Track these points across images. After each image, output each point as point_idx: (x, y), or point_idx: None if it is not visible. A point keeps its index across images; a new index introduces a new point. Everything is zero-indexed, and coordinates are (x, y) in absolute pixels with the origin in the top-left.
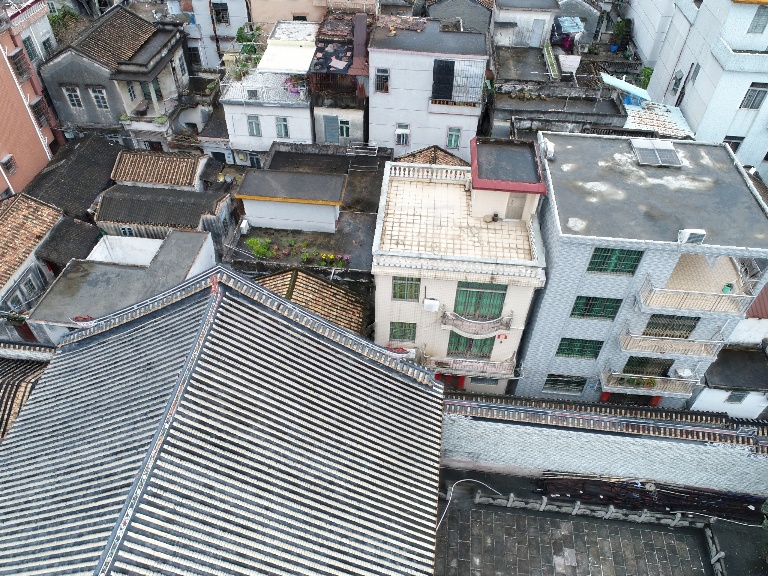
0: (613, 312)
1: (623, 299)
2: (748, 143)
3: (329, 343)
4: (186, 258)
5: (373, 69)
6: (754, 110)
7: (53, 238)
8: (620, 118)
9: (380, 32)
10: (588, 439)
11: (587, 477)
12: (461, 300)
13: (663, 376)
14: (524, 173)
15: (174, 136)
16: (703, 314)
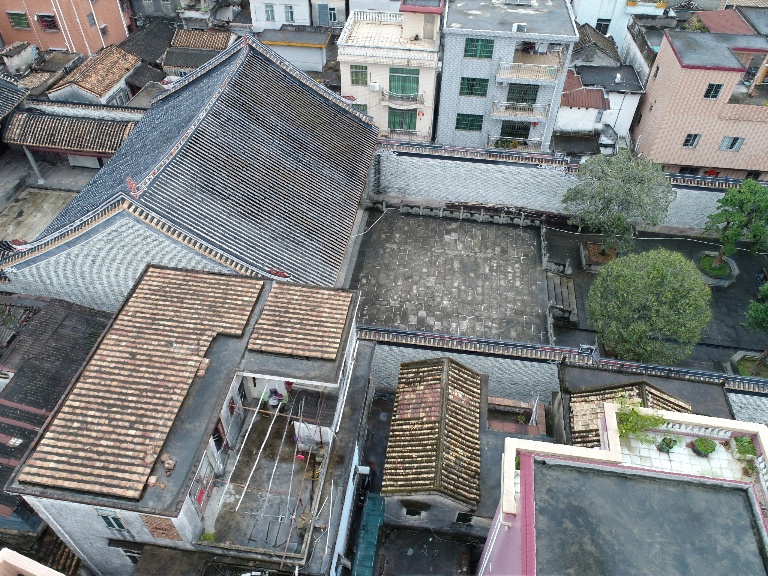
0: (485, 90)
1: (489, 79)
2: (614, 24)
3: (309, 90)
4: None
5: None
6: None
7: (135, 73)
8: None
9: None
10: (469, 168)
11: (473, 204)
12: (393, 84)
13: (524, 144)
14: (432, 5)
15: (214, 22)
16: (532, 81)
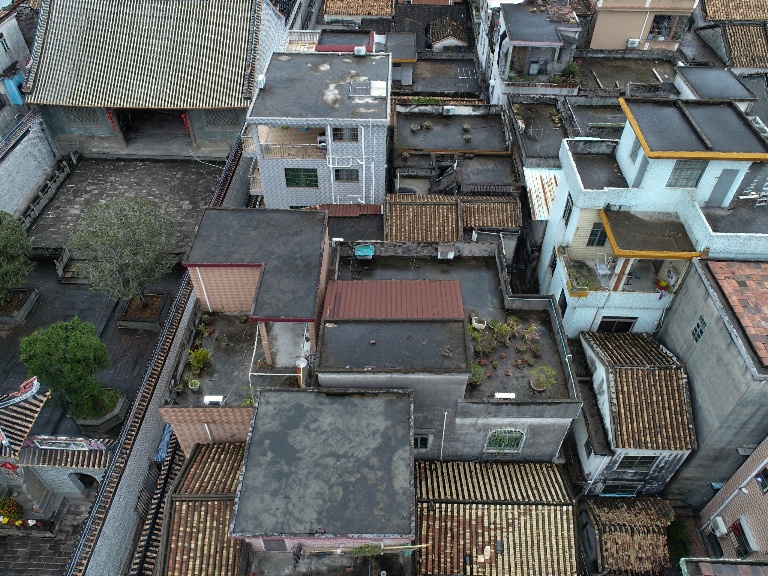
0: None
1: None
2: None
3: None
4: None
5: (499, 22)
6: (565, 228)
7: (376, 21)
8: (525, 155)
9: (535, 7)
10: None
11: None
12: None
13: None
14: None
15: None
16: None
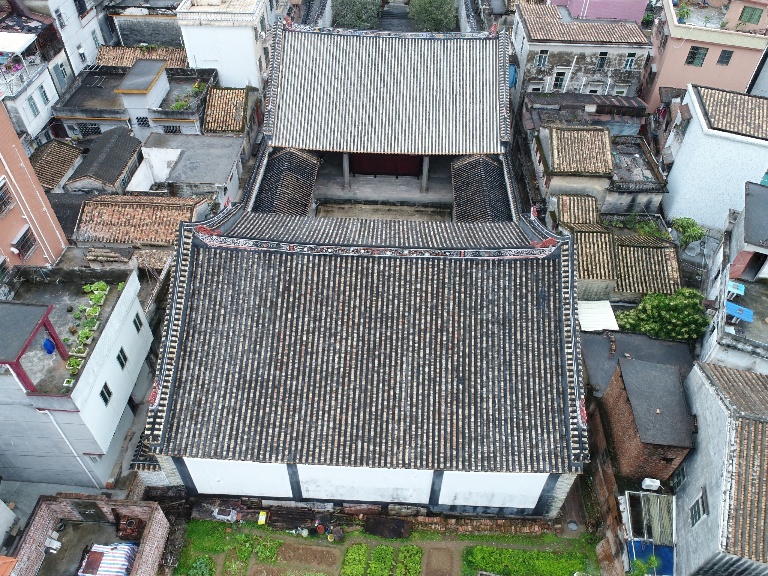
0: (272, 3)
1: None
2: None
3: None
4: (177, 138)
5: (54, 13)
6: None
7: None
8: None
9: None
10: None
11: None
12: (261, 29)
13: None
14: None
15: None
16: None
